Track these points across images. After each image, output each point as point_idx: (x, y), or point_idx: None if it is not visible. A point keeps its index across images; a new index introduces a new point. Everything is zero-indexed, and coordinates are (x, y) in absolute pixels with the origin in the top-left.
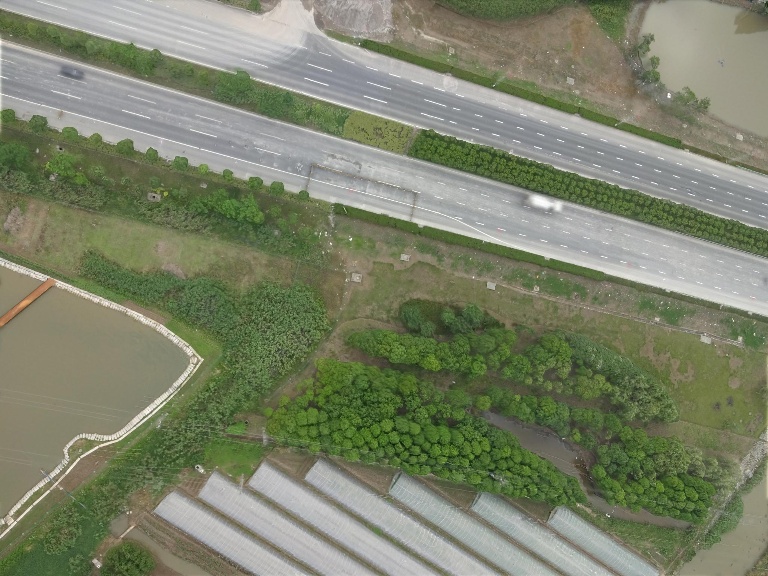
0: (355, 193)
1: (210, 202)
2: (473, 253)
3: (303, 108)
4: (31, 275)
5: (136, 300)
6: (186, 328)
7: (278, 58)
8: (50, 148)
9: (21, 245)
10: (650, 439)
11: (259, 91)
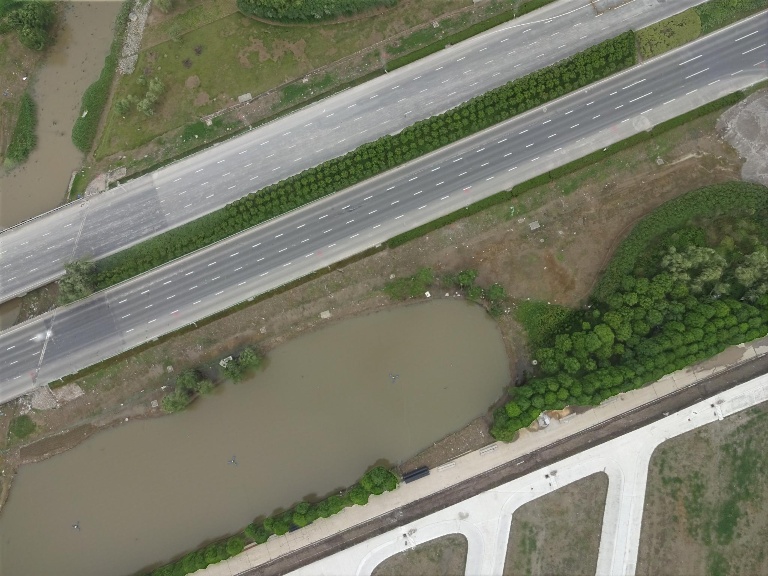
0: None
1: None
2: None
3: (741, 4)
4: None
5: None
6: None
7: None
8: None
9: None
10: None
11: None
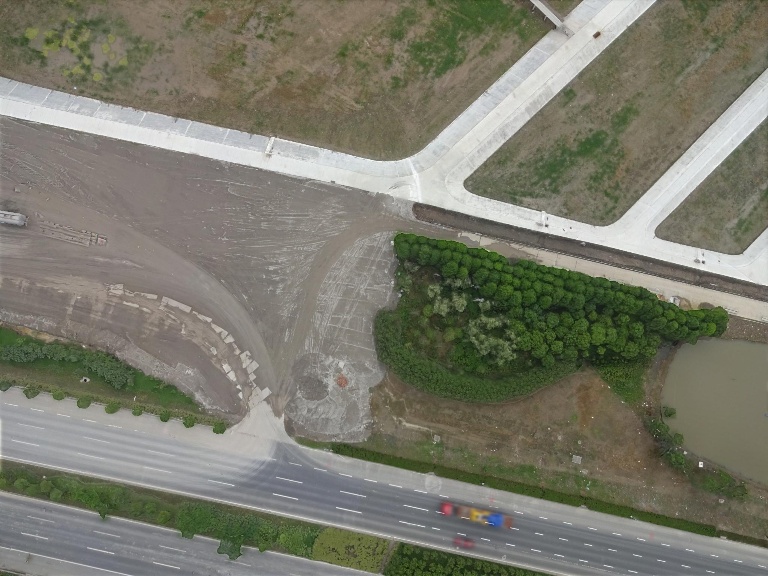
0: None
1: None
2: None
3: (269, 531)
4: None
5: None
6: None
7: (246, 474)
8: None
9: None
10: None
11: (223, 517)
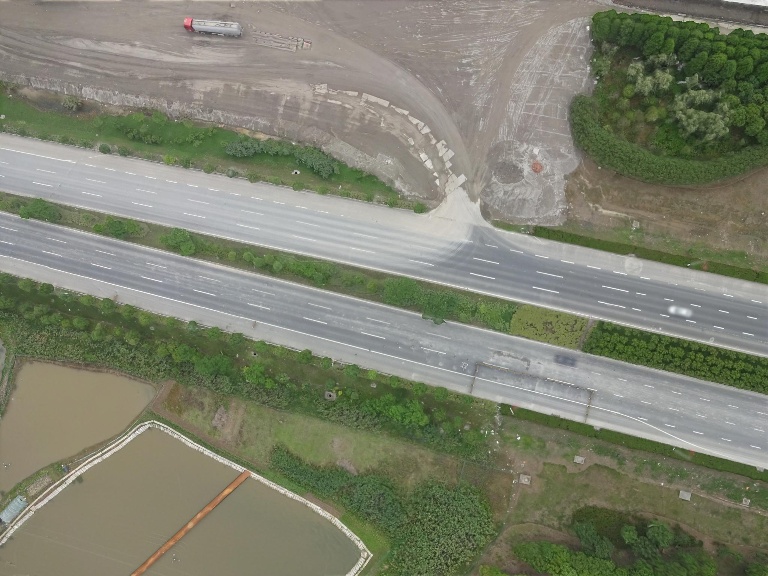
0: (523, 392)
1: (378, 407)
2: (661, 458)
3: (468, 306)
4: (232, 466)
5: (315, 493)
6: (357, 522)
7: (444, 255)
8: (247, 354)
9: (225, 439)
10: None
11: (425, 292)
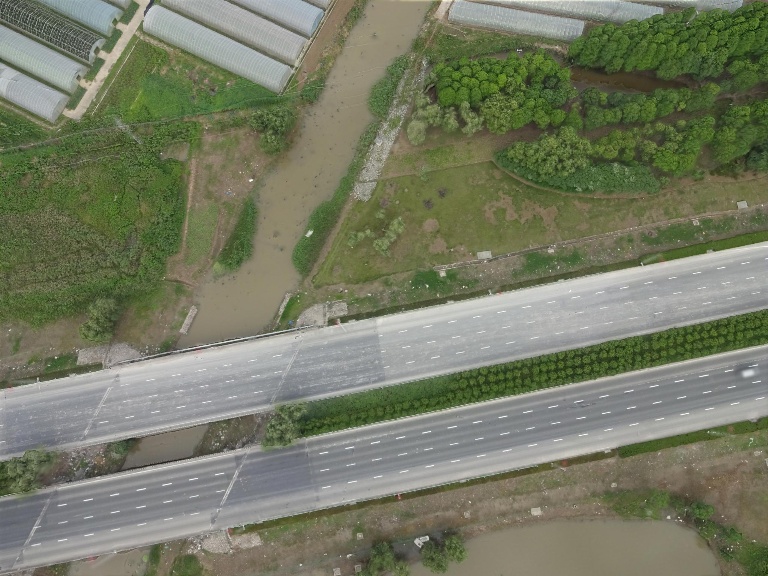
0: None
1: None
2: None
3: None
4: None
5: None
6: None
7: None
8: None
9: None
10: (528, 121)
11: None
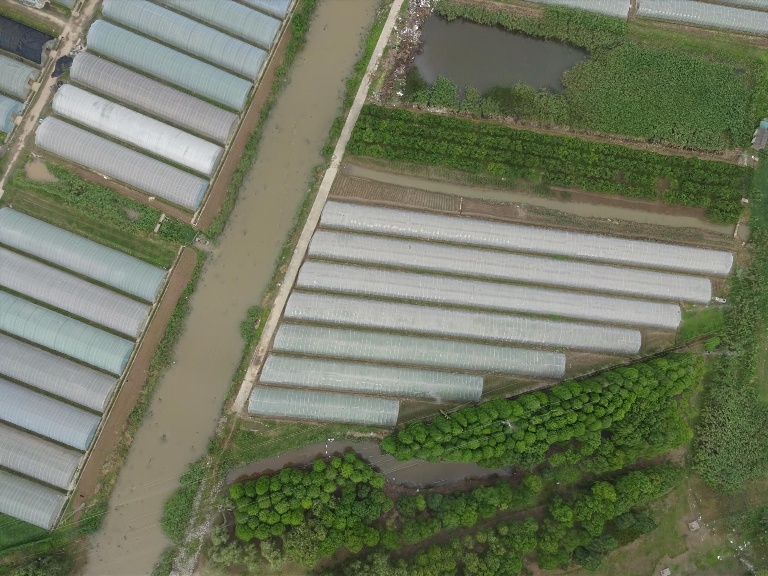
0: None
1: None
2: None
3: None
4: None
5: None
6: None
7: None
8: None
9: None
10: None
11: None
